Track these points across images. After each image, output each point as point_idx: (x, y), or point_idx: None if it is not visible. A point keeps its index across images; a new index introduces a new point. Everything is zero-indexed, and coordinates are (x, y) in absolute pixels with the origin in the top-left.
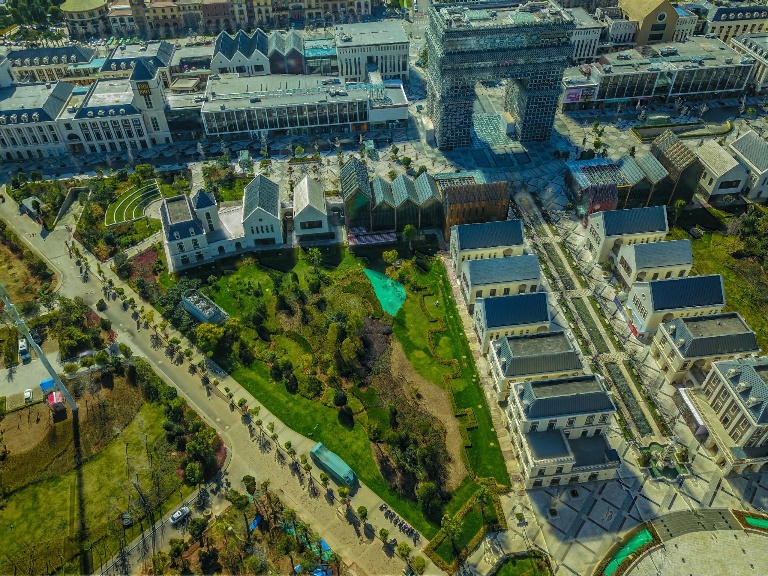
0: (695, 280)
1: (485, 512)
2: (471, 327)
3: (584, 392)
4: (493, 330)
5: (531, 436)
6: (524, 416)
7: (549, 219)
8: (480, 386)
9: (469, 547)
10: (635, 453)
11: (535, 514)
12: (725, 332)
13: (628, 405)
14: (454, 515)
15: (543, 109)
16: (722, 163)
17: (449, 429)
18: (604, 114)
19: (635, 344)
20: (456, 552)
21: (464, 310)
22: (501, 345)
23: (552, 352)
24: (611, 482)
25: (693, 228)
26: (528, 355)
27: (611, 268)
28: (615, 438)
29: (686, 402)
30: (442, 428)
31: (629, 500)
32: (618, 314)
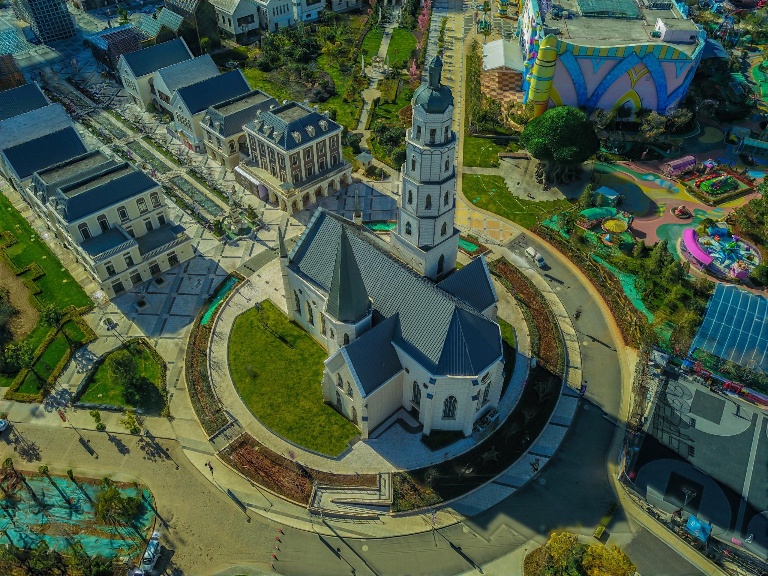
0: (218, 78)
1: (69, 335)
2: (19, 200)
3: None
4: (29, 180)
5: (87, 243)
6: (65, 222)
7: (89, 93)
8: (41, 241)
9: (57, 370)
10: (211, 231)
11: (124, 314)
12: None
13: (197, 200)
14: (33, 353)
15: (49, 0)
16: (230, 2)
17: (12, 289)
18: (129, 5)
19: (194, 156)
20: (43, 381)
21: (8, 189)
22: (34, 183)
23: (90, 169)
24: (193, 259)
25: (228, 63)
26: (63, 178)
27: (159, 110)
28: (190, 228)
29: (242, 174)
30: (2, 290)
31: (213, 265)
32: (174, 141)
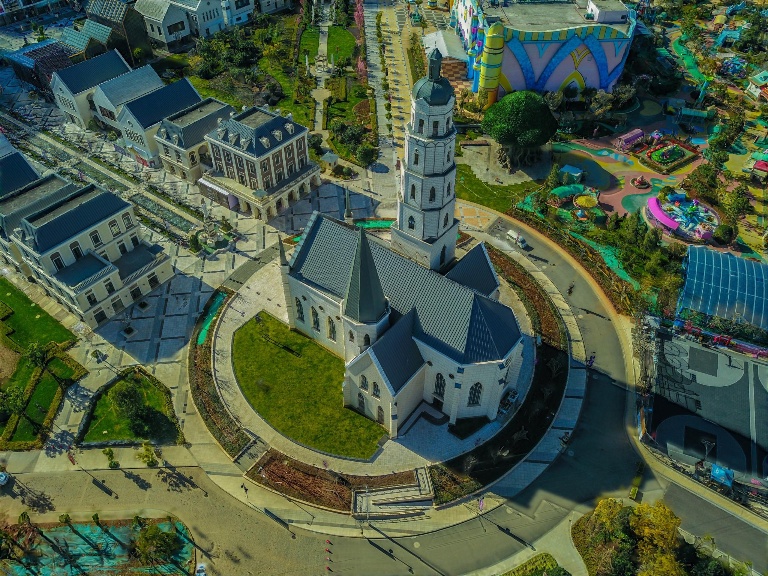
0: (166, 89)
1: (56, 373)
2: None
3: (88, 201)
4: None
5: (62, 273)
6: (36, 253)
7: (18, 115)
8: (1, 278)
9: (51, 412)
10: (186, 247)
11: (112, 343)
12: (207, 114)
13: (164, 217)
14: None
15: None
16: (158, 9)
17: None
18: (41, 19)
19: (150, 172)
20: (38, 425)
21: None
22: None
23: (49, 195)
24: (174, 278)
25: (164, 73)
26: (21, 207)
27: (101, 127)
28: (163, 246)
29: (208, 186)
30: None
31: (196, 282)
32: (124, 158)
